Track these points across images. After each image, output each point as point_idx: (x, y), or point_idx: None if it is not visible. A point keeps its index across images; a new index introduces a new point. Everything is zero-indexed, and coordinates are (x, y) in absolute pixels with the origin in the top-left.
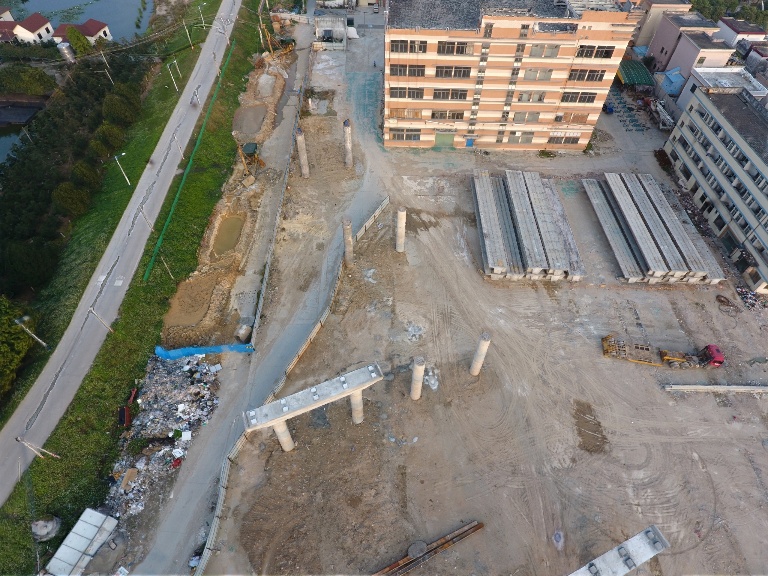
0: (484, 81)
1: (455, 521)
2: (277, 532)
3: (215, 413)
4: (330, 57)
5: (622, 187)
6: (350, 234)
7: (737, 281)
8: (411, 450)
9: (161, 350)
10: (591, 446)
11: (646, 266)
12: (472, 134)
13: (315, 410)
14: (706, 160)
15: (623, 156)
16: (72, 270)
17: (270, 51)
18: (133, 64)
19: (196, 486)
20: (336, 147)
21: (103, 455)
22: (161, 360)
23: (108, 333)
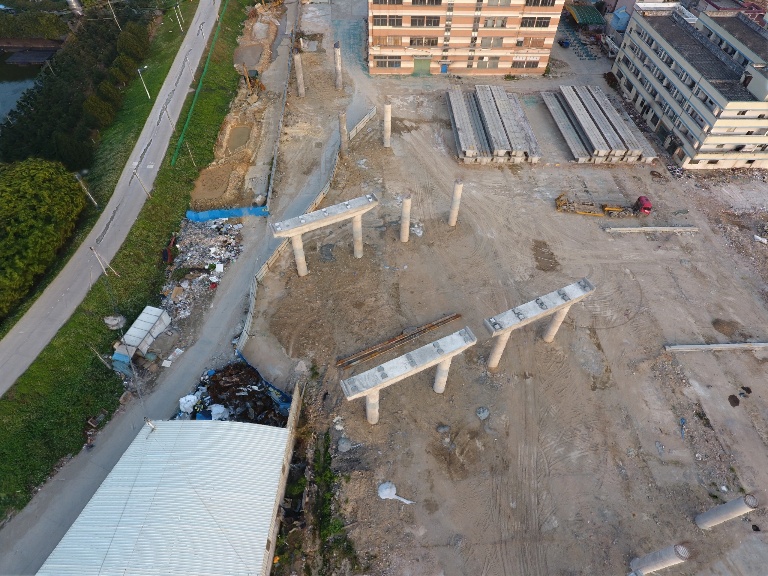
0: (454, 8)
1: (439, 314)
2: (299, 324)
3: (241, 255)
4: (317, 8)
5: (574, 95)
6: (345, 123)
7: (668, 161)
8: (402, 273)
9: (191, 213)
10: (546, 267)
11: (593, 149)
12: (446, 60)
13: (323, 251)
14: (643, 70)
15: (577, 78)
16: (108, 160)
17: (262, 3)
18: (137, 15)
19: (231, 300)
20: (327, 75)
21: (153, 280)
22: (192, 222)
23: (147, 199)
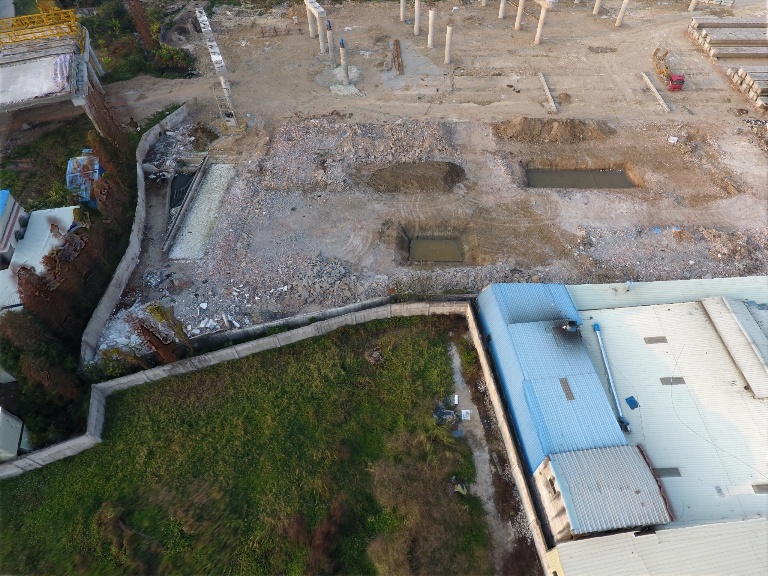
0: None
1: None
2: None
3: None
4: None
5: None
6: None
7: None
8: None
9: None
10: (592, 49)
11: None
12: None
13: None
14: None
15: None
16: None
17: None
18: None
19: None
20: None
21: None
22: None
23: None
